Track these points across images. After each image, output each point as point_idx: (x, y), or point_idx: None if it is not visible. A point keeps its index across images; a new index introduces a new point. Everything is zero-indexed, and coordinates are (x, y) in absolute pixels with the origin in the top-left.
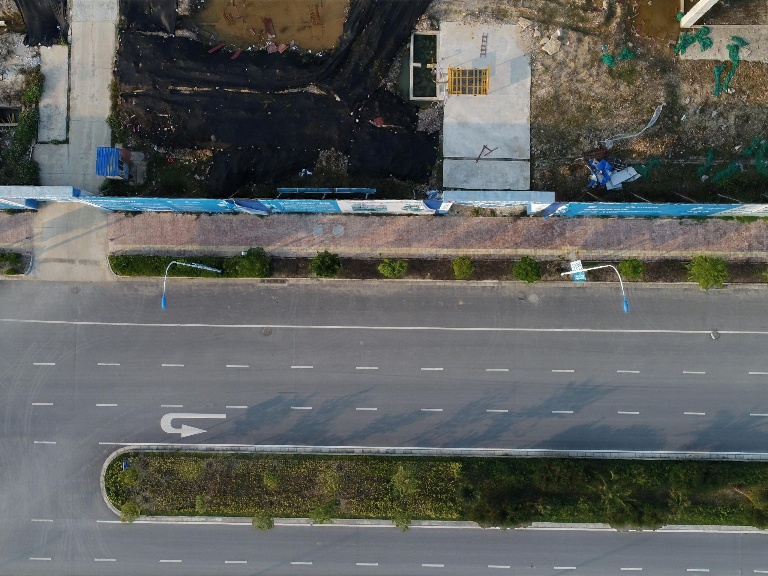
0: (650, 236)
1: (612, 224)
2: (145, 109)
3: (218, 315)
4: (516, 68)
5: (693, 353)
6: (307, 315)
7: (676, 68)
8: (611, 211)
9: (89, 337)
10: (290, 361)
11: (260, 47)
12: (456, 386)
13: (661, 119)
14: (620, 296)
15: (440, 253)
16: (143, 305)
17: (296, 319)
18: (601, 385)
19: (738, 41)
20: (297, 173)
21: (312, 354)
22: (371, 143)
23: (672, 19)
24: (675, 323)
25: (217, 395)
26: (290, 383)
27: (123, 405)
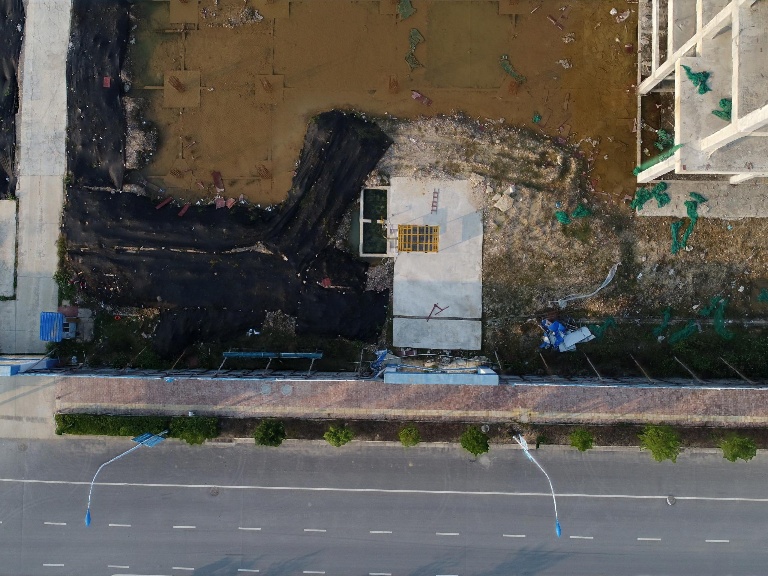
0: (604, 398)
1: (565, 386)
2: (91, 269)
3: (165, 474)
4: (468, 225)
5: (648, 519)
6: (255, 475)
7: (632, 225)
8: None
9: (36, 495)
10: (237, 522)
11: (209, 201)
12: (405, 550)
13: (616, 278)
14: (573, 459)
15: (389, 414)
16: (90, 463)
17: (244, 479)
18: (553, 551)
19: (696, 198)
20: (244, 333)
21: (259, 515)
22: (318, 305)
23: (629, 174)
24: (630, 488)
25: (164, 556)
26: (237, 545)
27: (69, 565)
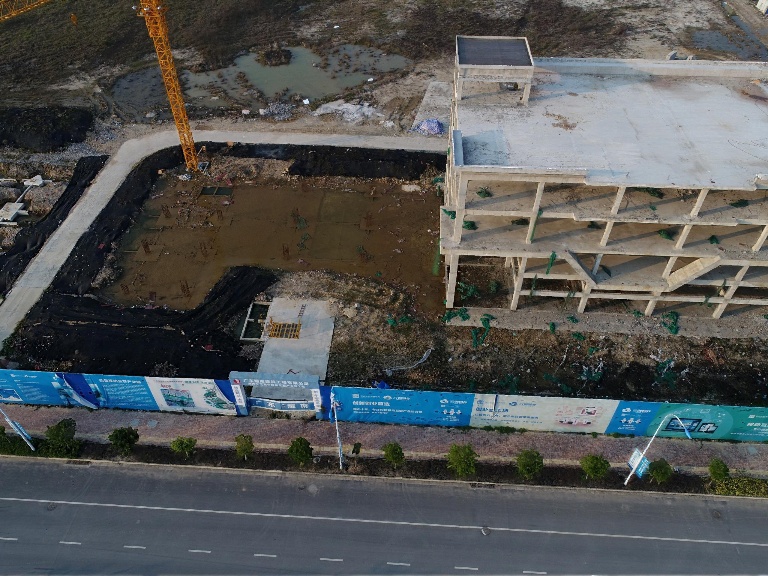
0: (422, 440)
1: (389, 429)
2: (35, 332)
3: (13, 489)
4: (323, 324)
5: (464, 548)
6: (96, 493)
7: (443, 330)
8: (380, 410)
9: None
10: (61, 536)
11: (141, 306)
12: (219, 570)
13: (431, 358)
14: (394, 490)
15: (235, 446)
16: None
17: (84, 497)
18: None
19: (488, 316)
20: None
21: (86, 530)
22: (198, 360)
23: (440, 303)
24: (446, 518)
25: None
26: (51, 559)
27: None
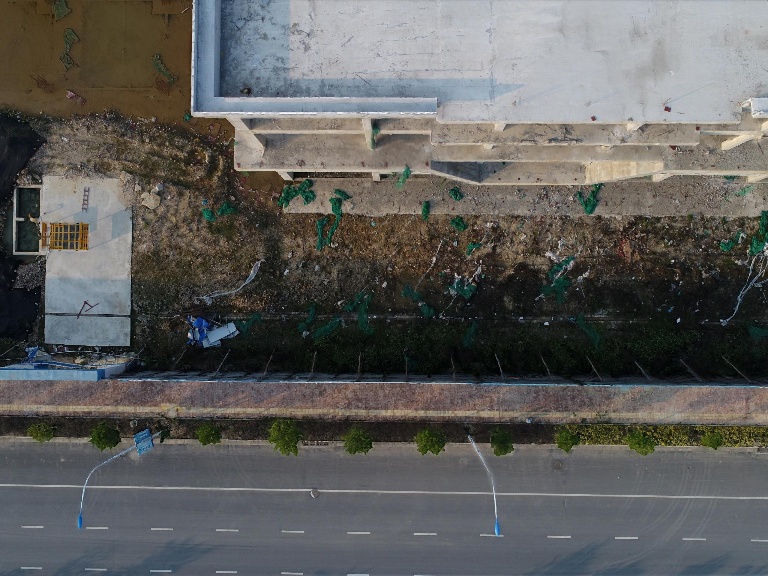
0: (249, 393)
1: None
2: None
3: None
4: (117, 223)
5: (292, 512)
6: None
7: (279, 222)
8: None
9: None
10: None
11: None
12: (56, 544)
13: (260, 275)
14: (221, 453)
15: (41, 410)
16: None
17: None
18: (200, 544)
19: (340, 195)
20: None
21: None
22: None
23: None
24: (275, 481)
25: None
26: None
27: None
